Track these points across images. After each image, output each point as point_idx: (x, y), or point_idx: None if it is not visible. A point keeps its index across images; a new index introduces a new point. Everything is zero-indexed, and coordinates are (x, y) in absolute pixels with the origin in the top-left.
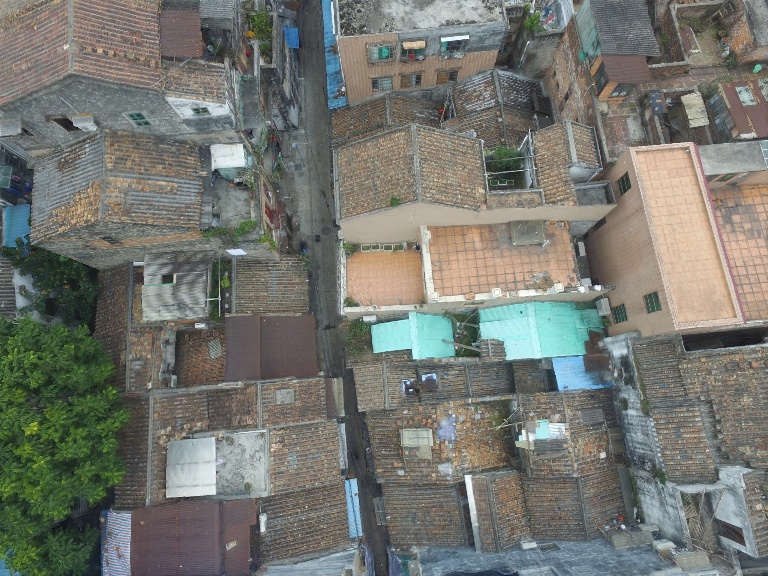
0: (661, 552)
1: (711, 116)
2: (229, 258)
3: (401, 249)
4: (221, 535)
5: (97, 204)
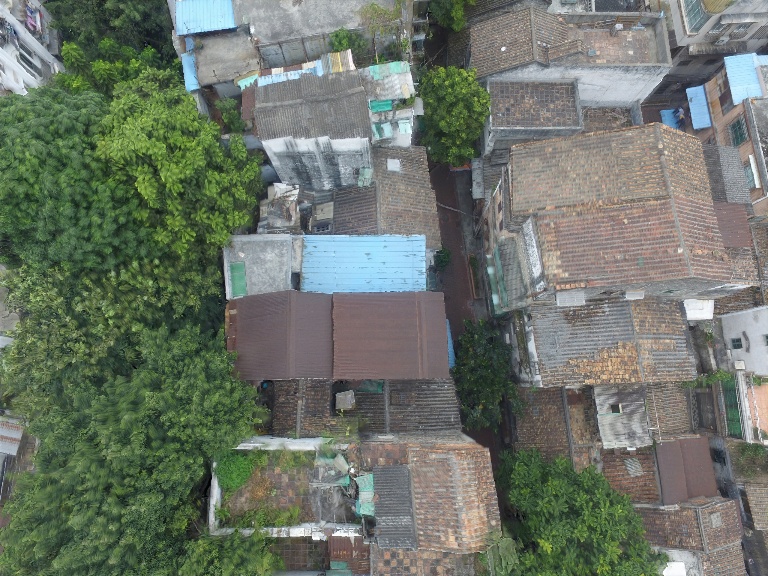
0: None
1: None
2: None
3: None
4: None
5: (635, 365)
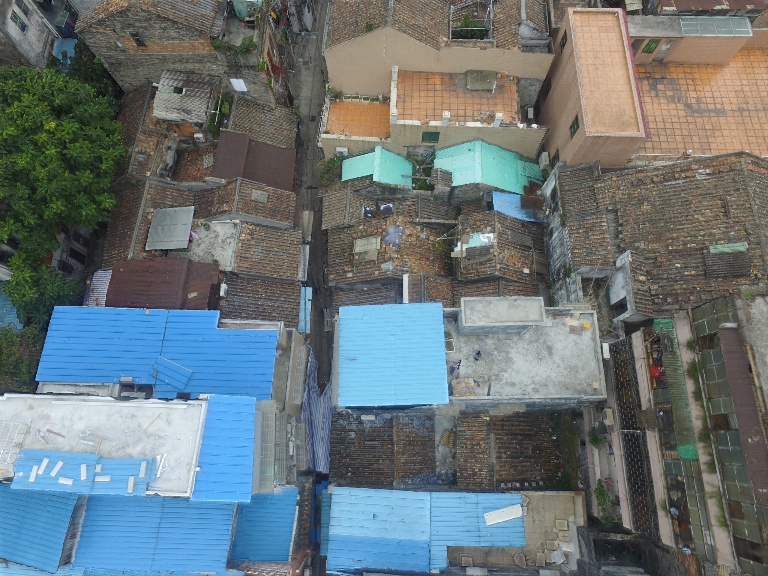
0: None
1: (645, 3)
2: (232, 94)
3: (377, 101)
4: (186, 285)
5: None
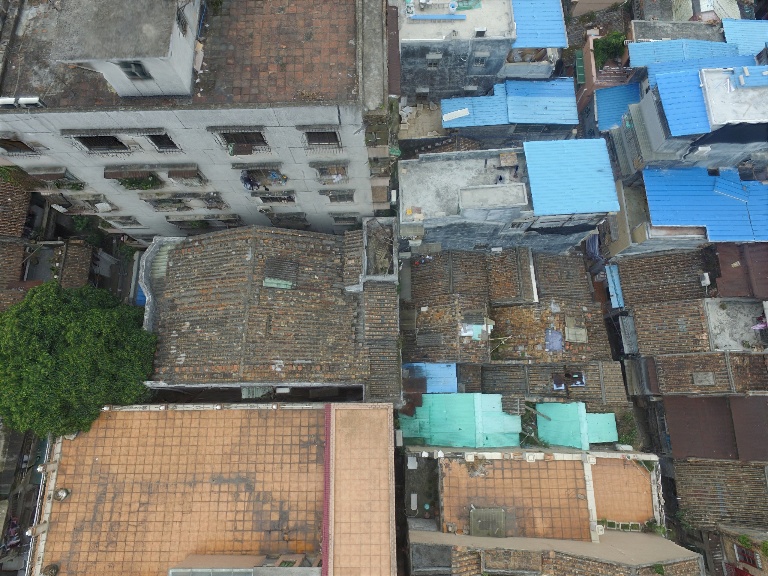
0: None
1: None
2: None
3: (598, 522)
4: (747, 272)
5: None
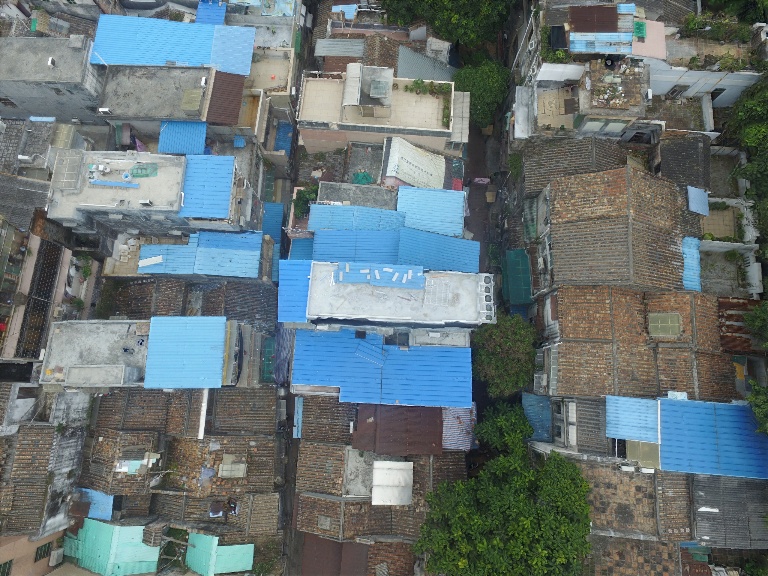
0: (75, 389)
1: None
2: None
3: None
4: (376, 429)
5: None
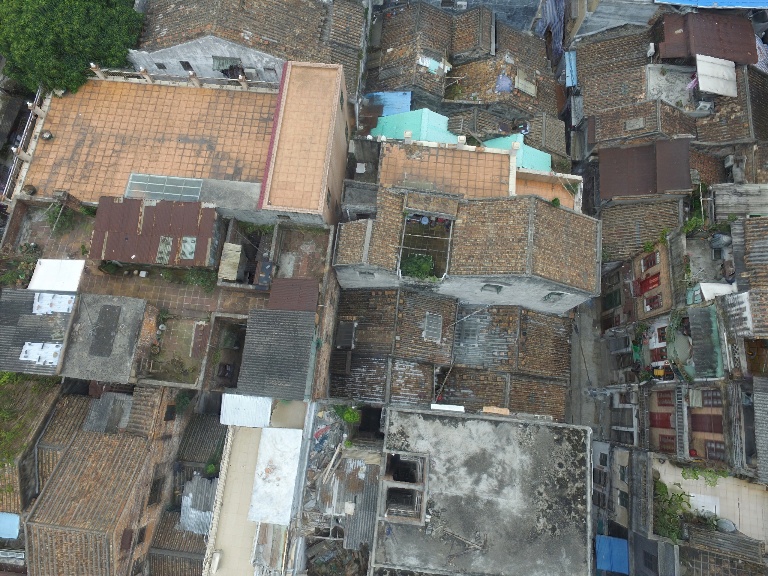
0: None
1: (218, 252)
2: None
3: None
4: (688, 37)
5: None
